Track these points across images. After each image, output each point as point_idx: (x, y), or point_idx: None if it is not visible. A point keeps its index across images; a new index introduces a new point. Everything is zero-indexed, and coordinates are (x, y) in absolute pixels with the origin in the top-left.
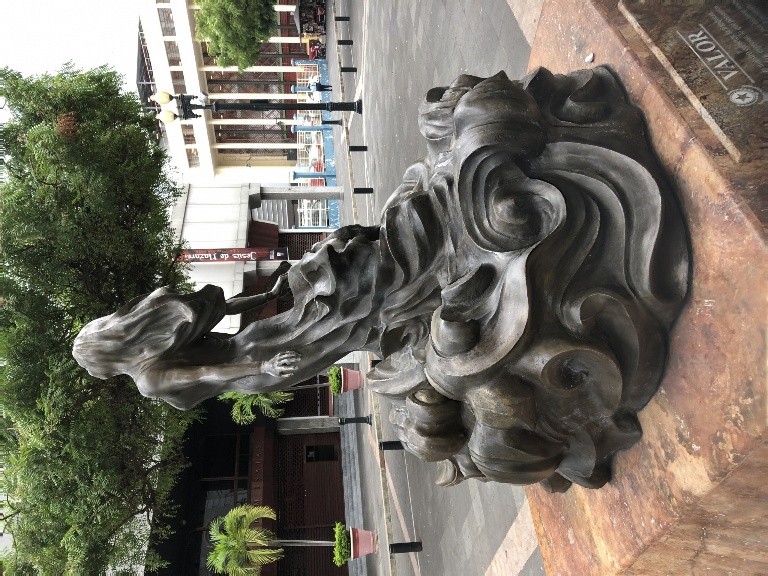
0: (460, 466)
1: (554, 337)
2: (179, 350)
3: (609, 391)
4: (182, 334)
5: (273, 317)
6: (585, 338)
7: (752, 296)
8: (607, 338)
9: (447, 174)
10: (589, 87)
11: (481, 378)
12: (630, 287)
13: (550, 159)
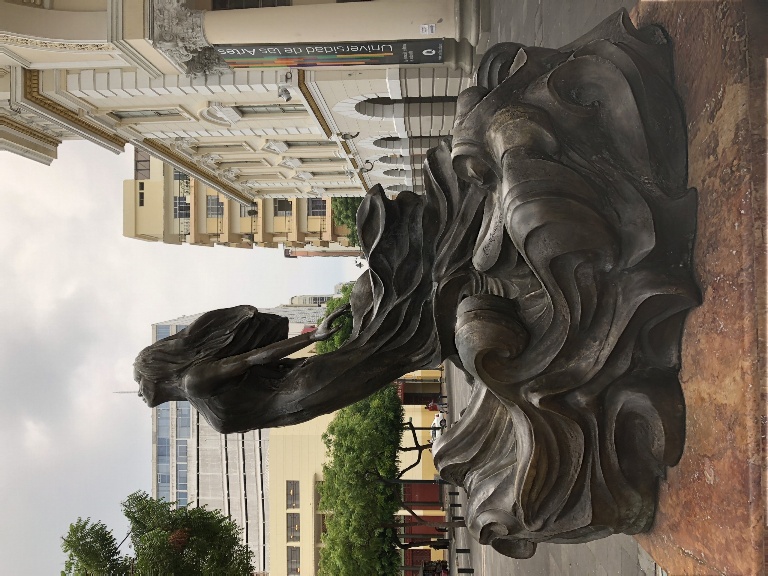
0: (530, 395)
1: None
2: None
3: (625, 111)
4: (241, 339)
5: None
6: None
7: None
8: None
9: None
10: None
11: (494, 102)
12: None
13: None
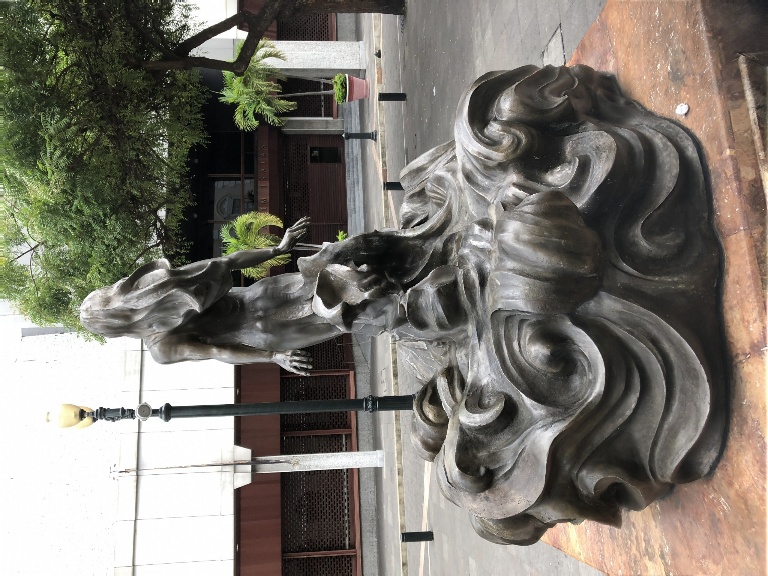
0: None
1: (564, 500)
2: (188, 323)
3: None
4: (190, 313)
5: (282, 279)
6: (594, 503)
7: (766, 552)
8: (616, 487)
9: (481, 261)
10: (669, 201)
11: None
12: (651, 470)
13: (600, 307)
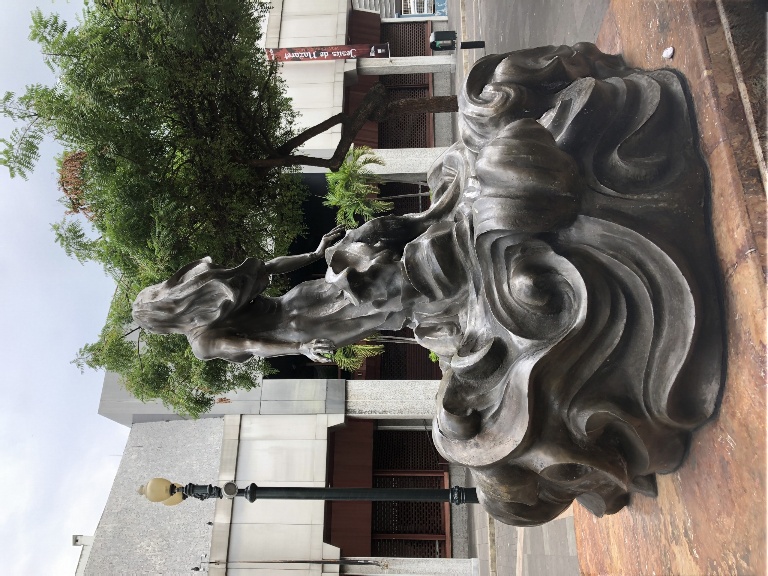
0: None
1: (556, 444)
2: (227, 318)
3: (616, 482)
4: (227, 306)
5: (317, 281)
6: (589, 448)
7: (767, 476)
8: (619, 438)
9: None
10: (648, 127)
11: (479, 468)
12: (646, 405)
13: (581, 232)
